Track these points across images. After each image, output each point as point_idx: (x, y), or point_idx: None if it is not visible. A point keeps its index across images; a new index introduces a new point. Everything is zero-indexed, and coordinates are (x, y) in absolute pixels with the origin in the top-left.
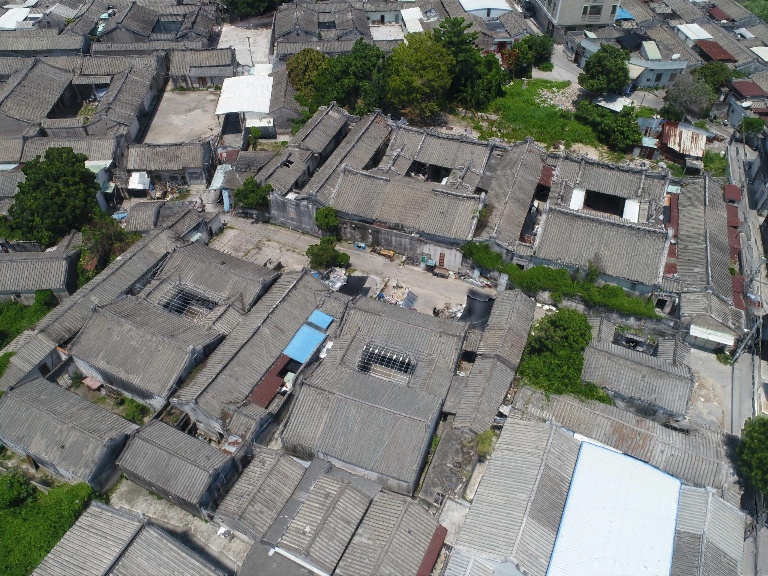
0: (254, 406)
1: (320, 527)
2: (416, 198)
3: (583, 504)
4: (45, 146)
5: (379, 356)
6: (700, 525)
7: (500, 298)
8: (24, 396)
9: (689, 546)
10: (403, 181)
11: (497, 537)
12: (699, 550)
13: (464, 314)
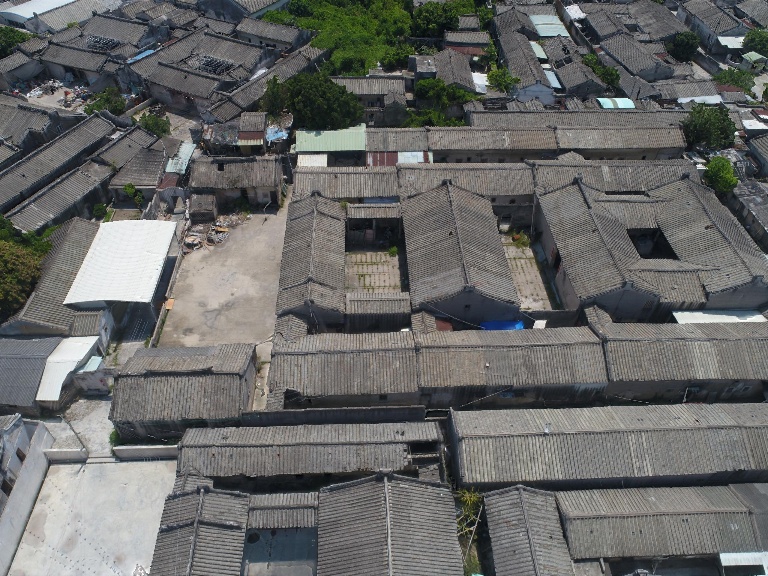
0: (180, 36)
1: (159, 5)
2: (6, 102)
3: (48, 7)
4: (374, 171)
5: (104, 40)
6: (8, 4)
7: (5, 68)
8: (292, 29)
9: (19, 3)
10: (4, 116)
11: (91, 3)
12: (16, 0)
13: (36, 73)
